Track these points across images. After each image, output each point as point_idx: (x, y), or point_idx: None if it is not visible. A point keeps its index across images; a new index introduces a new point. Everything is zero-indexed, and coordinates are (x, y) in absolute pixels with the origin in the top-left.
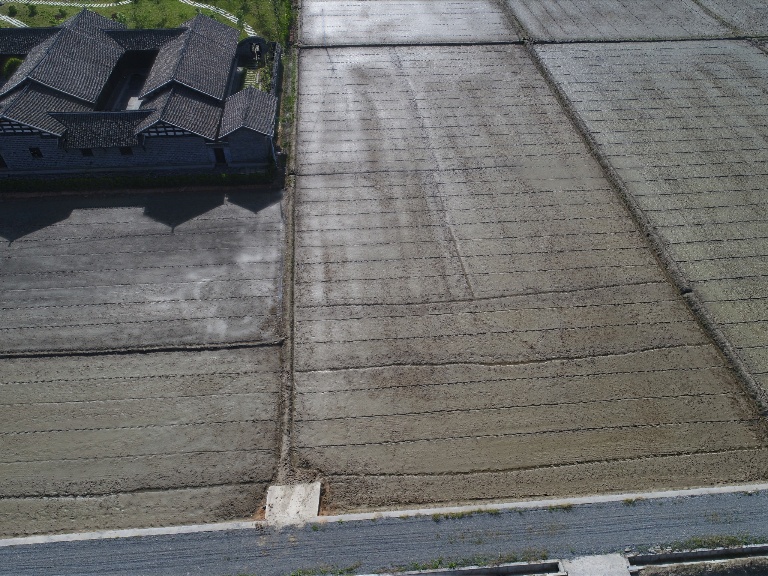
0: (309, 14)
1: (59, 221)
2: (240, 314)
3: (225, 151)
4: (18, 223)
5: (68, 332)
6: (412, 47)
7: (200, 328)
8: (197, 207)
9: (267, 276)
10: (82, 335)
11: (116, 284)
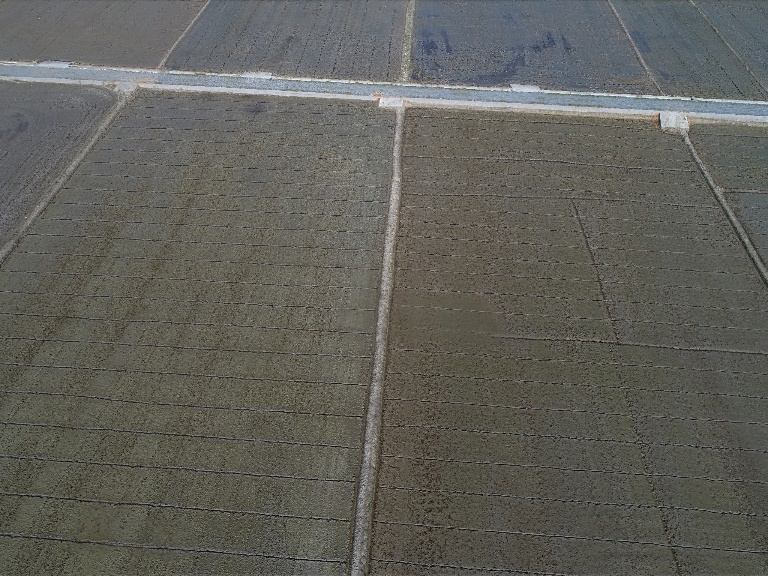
0: None
1: None
2: (764, 210)
3: None
4: None
5: None
6: None
7: None
8: None
9: (760, 236)
10: None
11: None
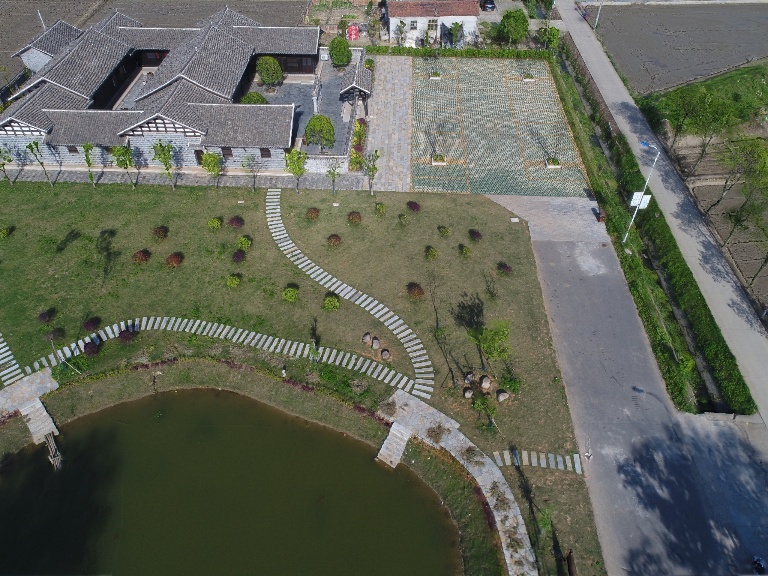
0: None
1: None
2: (123, 4)
3: None
4: None
5: (206, 3)
6: None
7: (144, 1)
8: None
9: None
10: (199, 2)
11: None
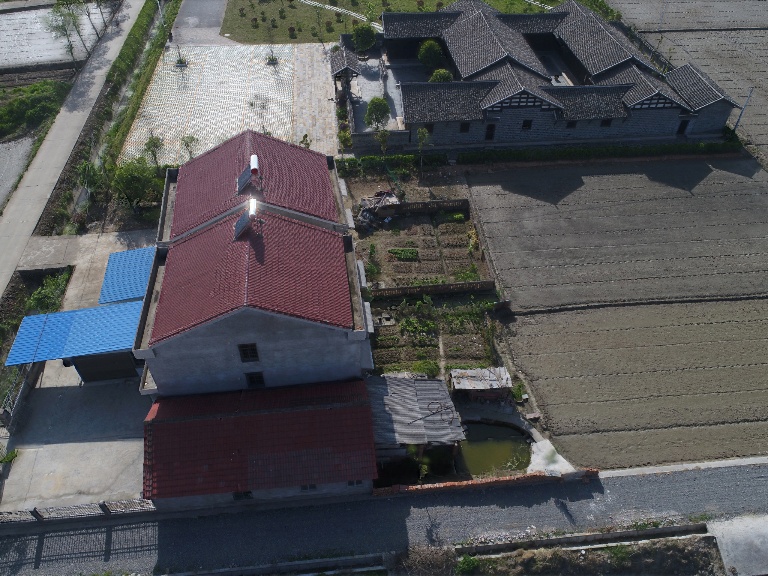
0: (611, 2)
1: (580, 187)
2: None
3: (690, 123)
4: (544, 189)
5: (693, 281)
6: (738, 31)
7: None
8: (692, 173)
9: None
10: (709, 283)
11: (692, 240)
